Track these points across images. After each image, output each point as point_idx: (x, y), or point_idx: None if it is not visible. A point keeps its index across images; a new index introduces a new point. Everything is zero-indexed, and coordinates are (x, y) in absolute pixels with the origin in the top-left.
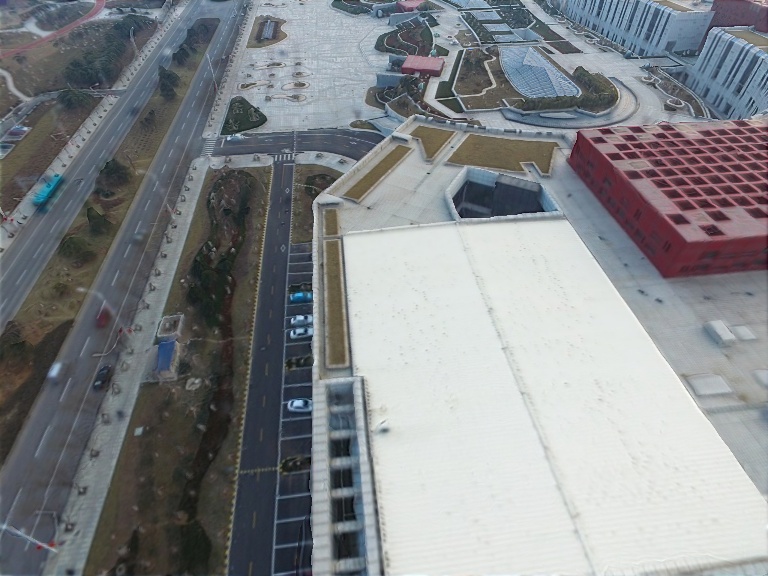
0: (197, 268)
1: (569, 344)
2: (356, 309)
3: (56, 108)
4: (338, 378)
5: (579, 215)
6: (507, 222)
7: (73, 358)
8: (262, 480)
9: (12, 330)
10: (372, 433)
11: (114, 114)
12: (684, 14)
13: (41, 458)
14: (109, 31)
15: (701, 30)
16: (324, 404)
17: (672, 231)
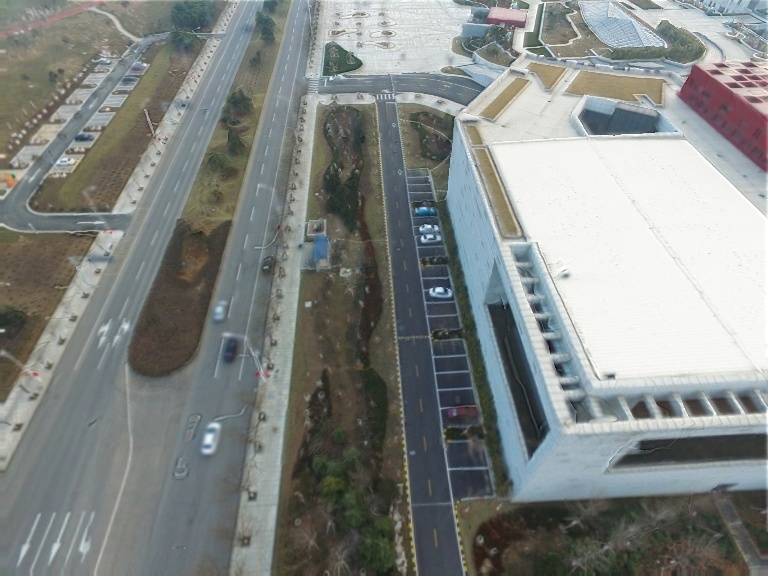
0: (331, 183)
1: (706, 228)
2: (516, 197)
3: (167, 48)
4: (517, 242)
5: (695, 138)
6: (633, 139)
7: (239, 249)
8: (418, 344)
9: (185, 224)
10: (554, 279)
11: (220, 55)
12: None
13: (233, 319)
14: None
15: None
16: (512, 258)
17: None
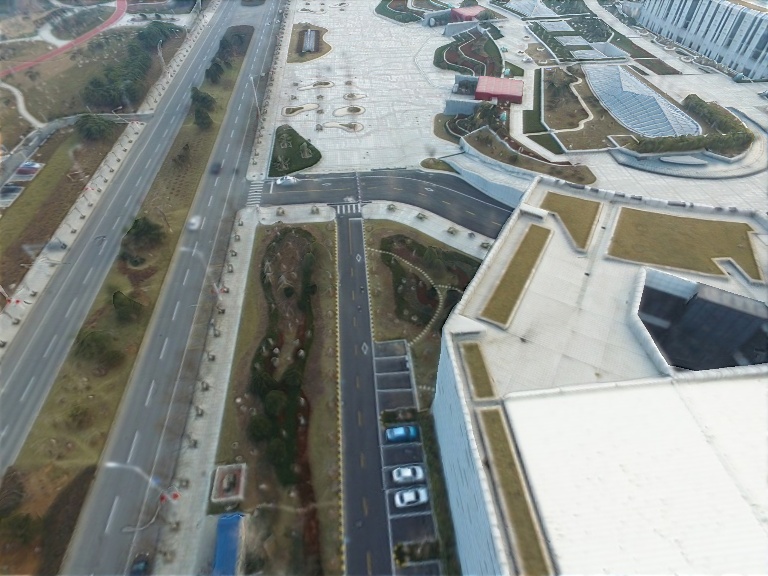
0: (258, 385)
1: None
2: None
3: (73, 138)
4: None
5: None
6: (746, 378)
7: (96, 535)
8: None
9: (12, 487)
10: None
11: (141, 146)
12: None
13: None
14: (132, 41)
15: None
16: None
17: None
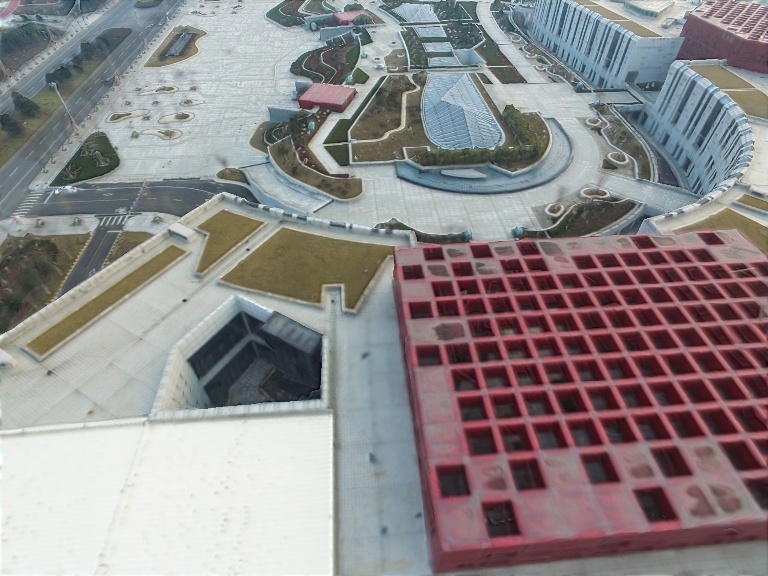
0: None
1: None
2: None
3: None
4: None
5: (361, 400)
6: (231, 420)
7: None
8: None
9: None
10: None
11: None
12: (646, 40)
13: None
14: None
15: (668, 59)
16: None
17: (433, 511)
